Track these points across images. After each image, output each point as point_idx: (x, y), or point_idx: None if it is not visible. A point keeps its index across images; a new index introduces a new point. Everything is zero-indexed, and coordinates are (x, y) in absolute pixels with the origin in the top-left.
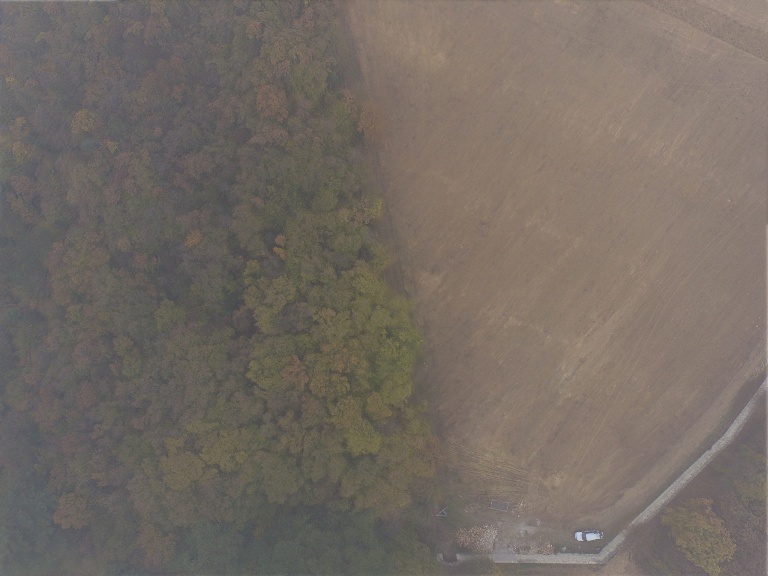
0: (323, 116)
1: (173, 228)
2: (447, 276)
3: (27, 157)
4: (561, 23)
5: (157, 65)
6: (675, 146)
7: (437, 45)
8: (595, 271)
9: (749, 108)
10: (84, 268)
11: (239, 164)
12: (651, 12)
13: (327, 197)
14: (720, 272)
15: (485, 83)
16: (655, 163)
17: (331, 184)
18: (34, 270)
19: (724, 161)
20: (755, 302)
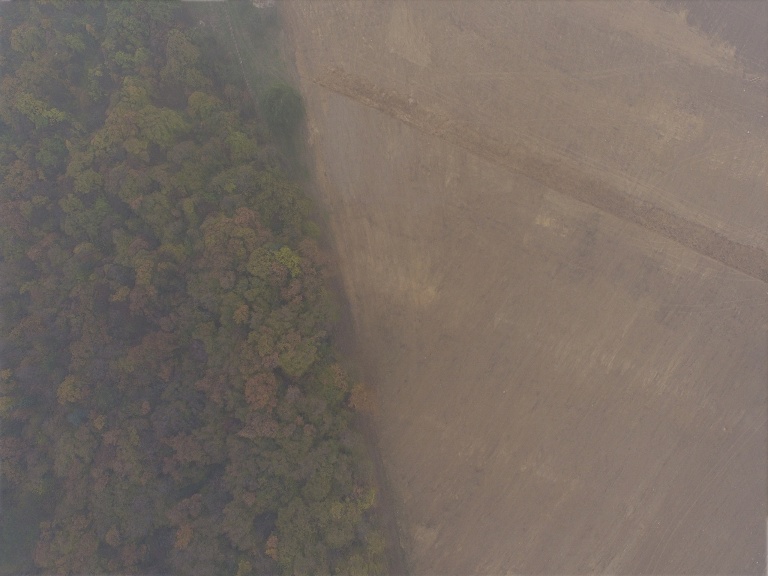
0: (313, 391)
1: (163, 520)
2: (443, 530)
3: (13, 415)
4: (550, 248)
5: (144, 337)
6: (668, 373)
7: (427, 279)
8: (592, 515)
9: (741, 329)
10: (72, 558)
11: (229, 455)
12: (640, 232)
13: (319, 485)
14: (718, 507)
15: (476, 318)
16: (649, 393)
17: (323, 470)
18: (21, 549)
19: (718, 387)
20: (754, 536)
